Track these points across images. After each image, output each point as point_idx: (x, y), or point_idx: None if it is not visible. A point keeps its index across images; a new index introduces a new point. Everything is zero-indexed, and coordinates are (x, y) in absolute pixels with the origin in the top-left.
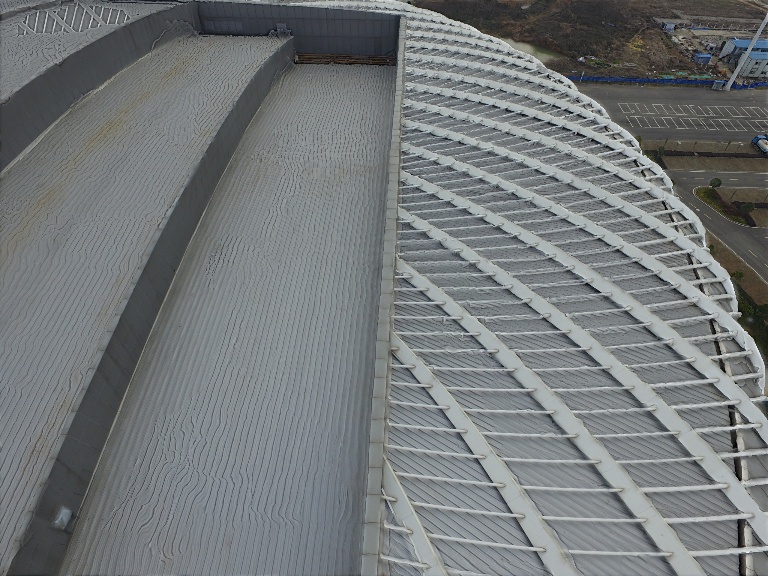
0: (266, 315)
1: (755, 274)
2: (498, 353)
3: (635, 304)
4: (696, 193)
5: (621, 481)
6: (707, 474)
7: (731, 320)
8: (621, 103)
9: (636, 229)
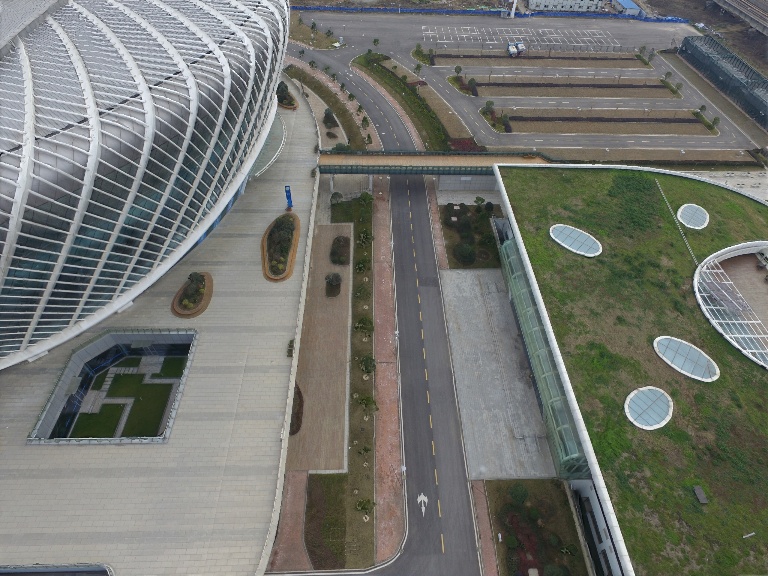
0: (8, 32)
1: (460, 120)
2: (98, 25)
3: (185, 19)
4: (447, 79)
5: (123, 52)
6: (173, 60)
7: (242, 32)
8: (424, 26)
9: (221, 4)
